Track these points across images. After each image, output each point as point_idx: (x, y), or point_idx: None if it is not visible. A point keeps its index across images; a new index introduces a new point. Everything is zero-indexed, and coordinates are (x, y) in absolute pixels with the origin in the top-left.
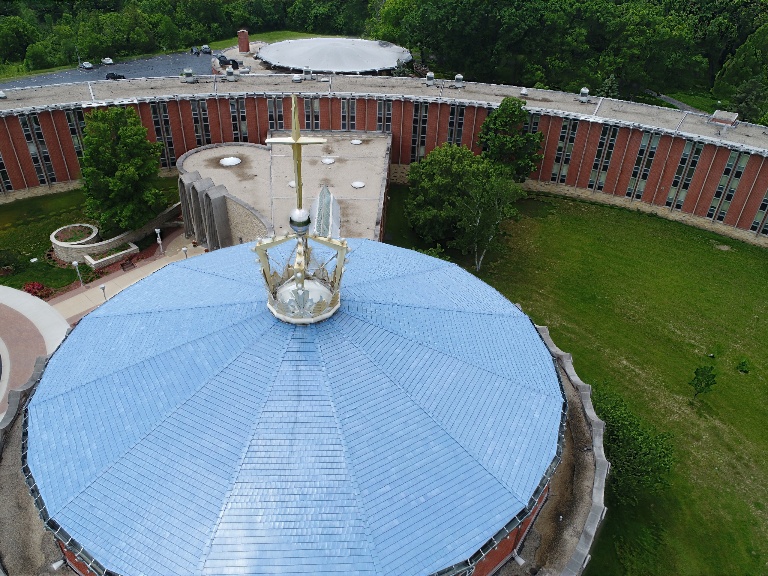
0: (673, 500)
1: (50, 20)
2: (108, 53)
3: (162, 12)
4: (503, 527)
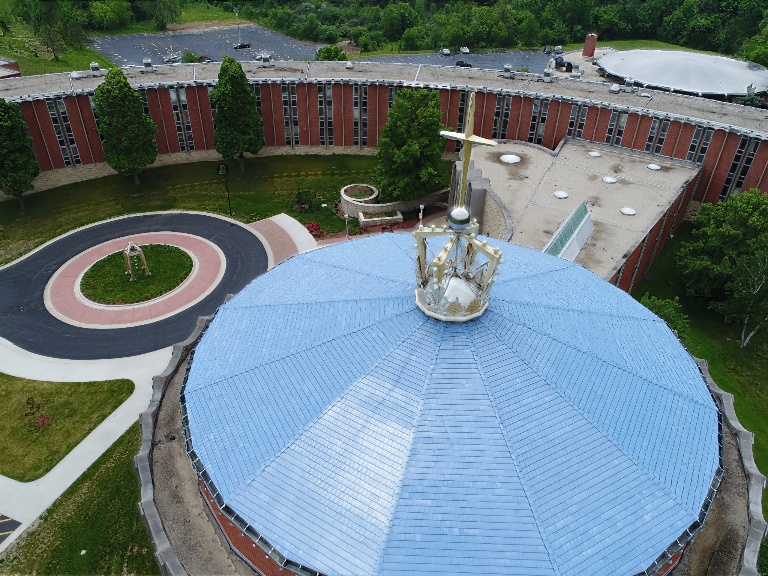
0: None
1: (434, 9)
2: (469, 43)
3: (531, 10)
4: None
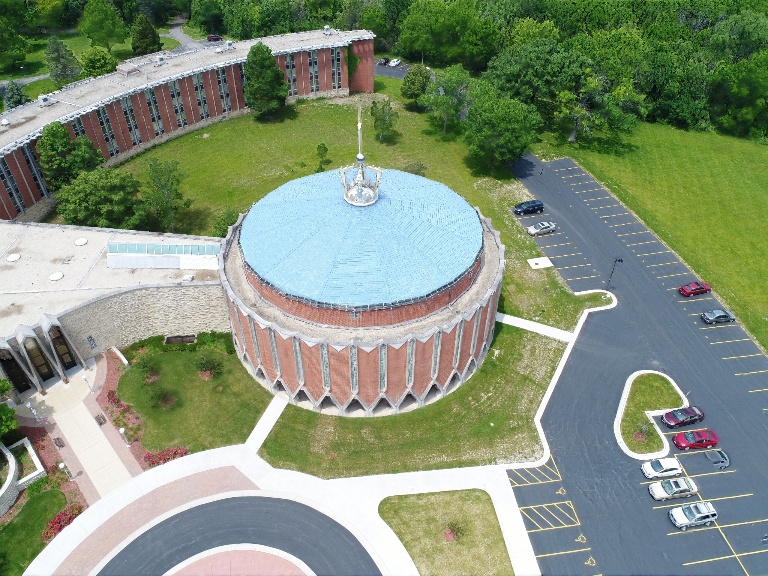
0: None
1: None
2: None
3: None
4: None
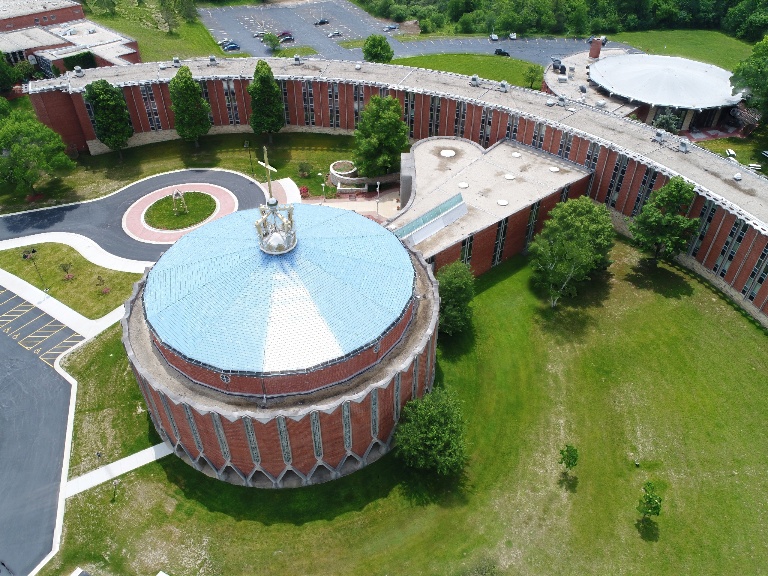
0: (465, 500)
1: None
2: (521, 28)
3: None
4: (246, 371)
